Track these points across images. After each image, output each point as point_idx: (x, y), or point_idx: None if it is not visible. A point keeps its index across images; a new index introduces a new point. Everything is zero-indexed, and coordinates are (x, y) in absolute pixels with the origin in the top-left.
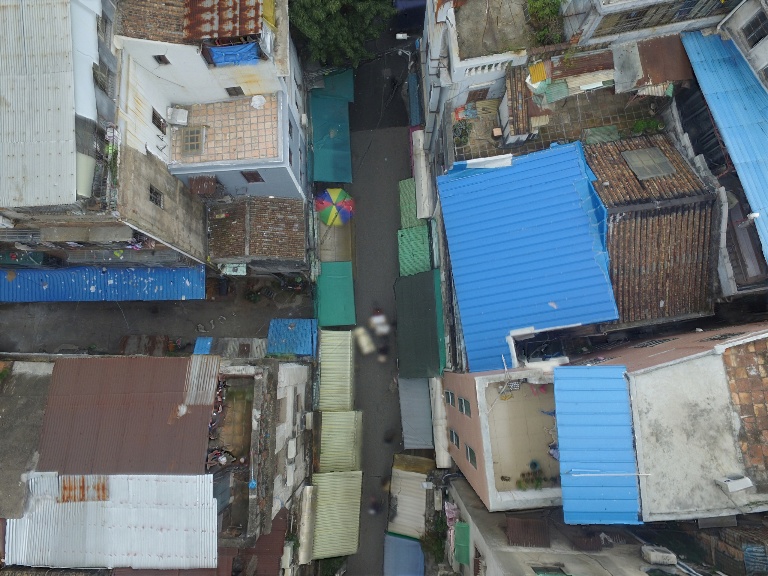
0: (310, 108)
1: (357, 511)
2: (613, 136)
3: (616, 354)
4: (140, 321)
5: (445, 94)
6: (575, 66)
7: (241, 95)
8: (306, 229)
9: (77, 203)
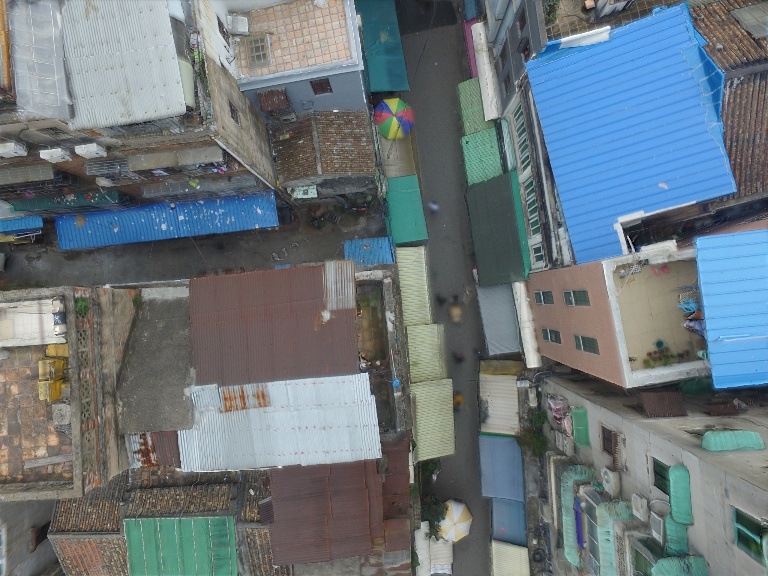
0: (357, 11)
1: (451, 415)
2: None
3: (726, 231)
4: (208, 258)
5: None
6: None
7: None
8: None
9: (175, 120)
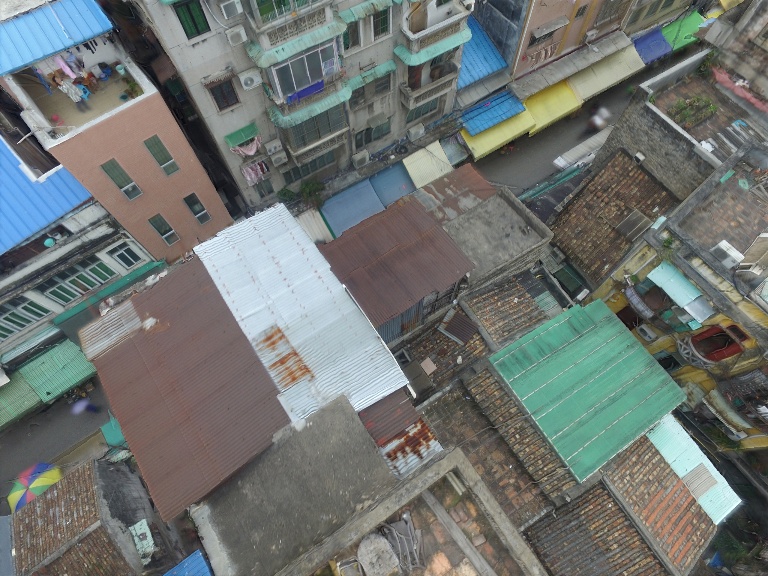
0: None
1: None
2: None
3: None
4: None
5: None
6: None
7: None
8: None
9: None
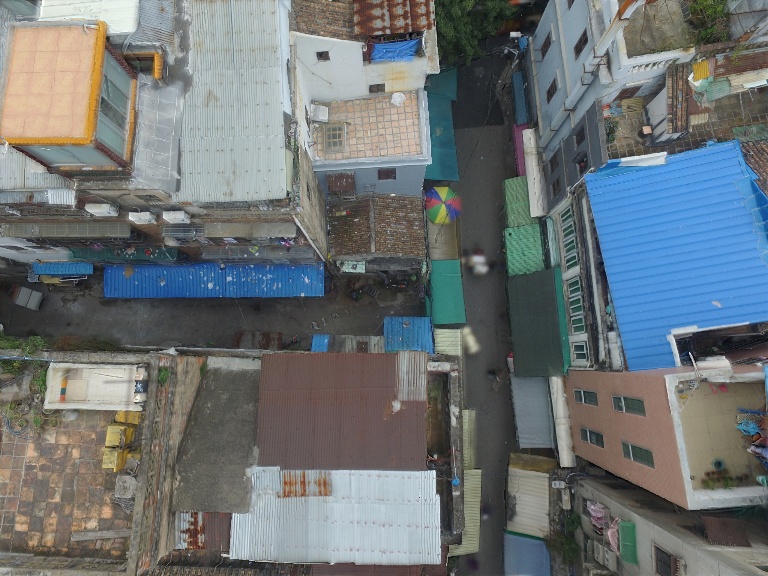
0: None
1: (478, 510)
2: (762, 135)
3: None
4: None
5: (595, 92)
6: (739, 64)
7: (381, 92)
8: None
9: None
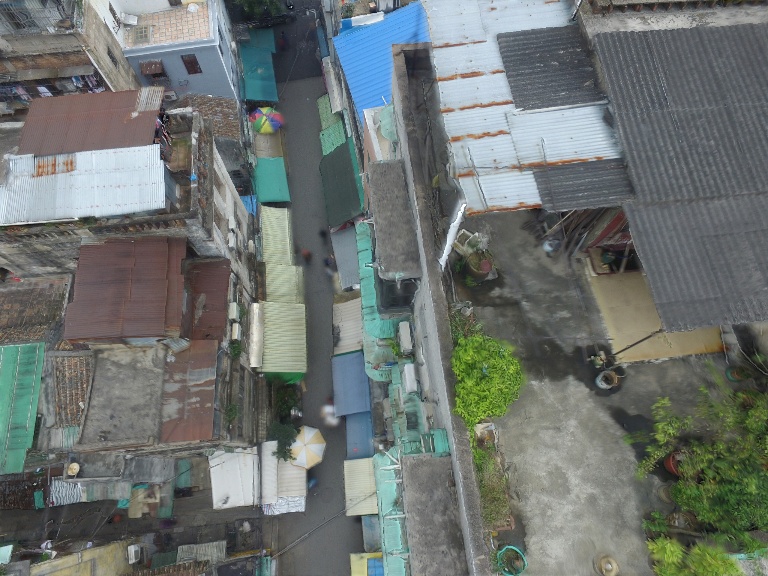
0: (240, 52)
1: (303, 337)
2: None
3: None
4: None
5: None
6: None
7: (179, 5)
8: (241, 125)
9: (51, 20)
